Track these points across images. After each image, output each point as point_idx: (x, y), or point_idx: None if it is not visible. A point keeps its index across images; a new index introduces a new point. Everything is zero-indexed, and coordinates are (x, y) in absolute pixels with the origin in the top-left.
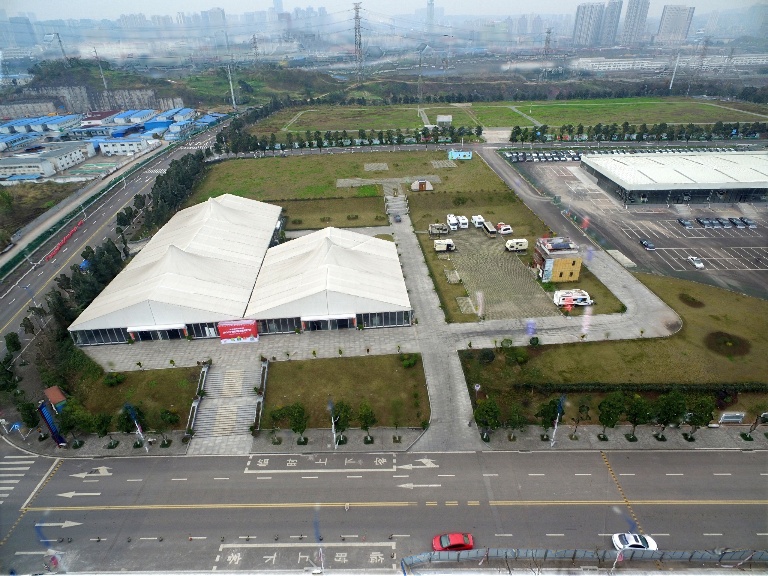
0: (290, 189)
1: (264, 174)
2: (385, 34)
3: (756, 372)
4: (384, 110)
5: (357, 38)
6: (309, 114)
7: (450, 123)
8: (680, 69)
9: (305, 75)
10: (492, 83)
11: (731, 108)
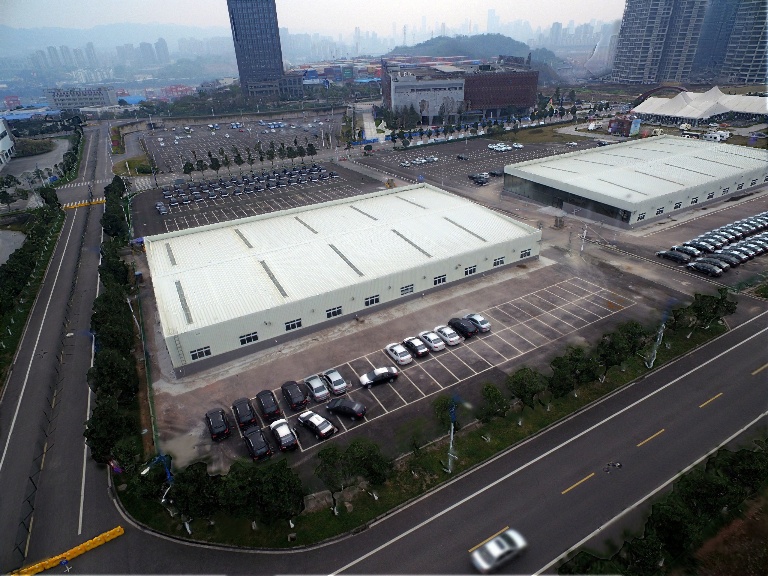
0: None
1: None
2: None
3: None
4: None
5: None
6: None
7: None
8: None
9: None
10: None
11: None
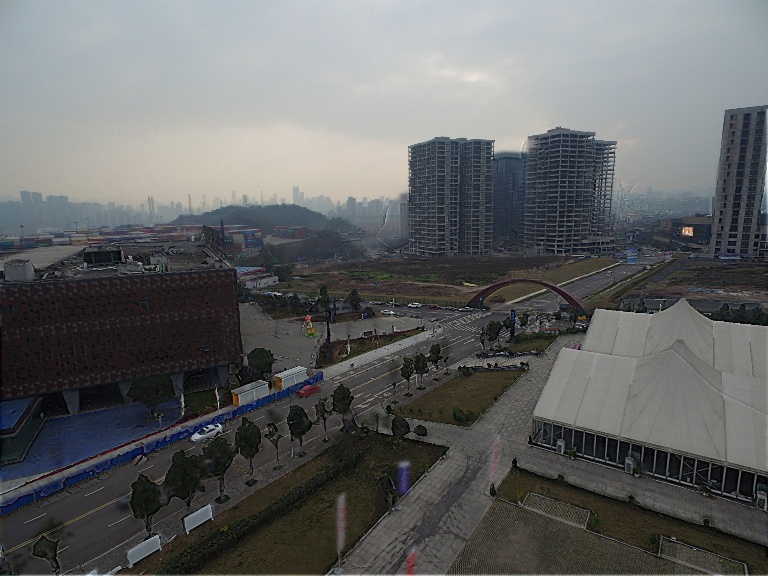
0: None
1: None
2: None
3: None
4: None
5: None
6: None
7: None
8: None
9: None
10: None
11: None
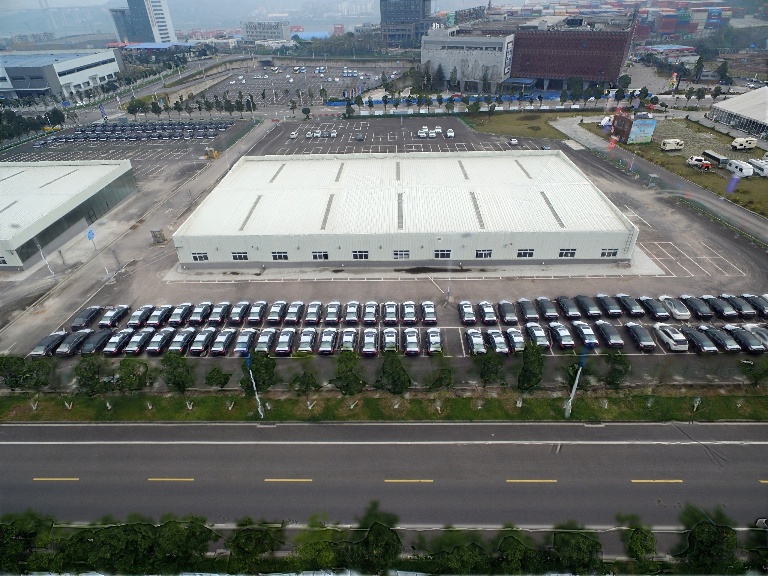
0: None
1: None
2: None
3: (523, 114)
4: None
5: None
6: None
7: None
8: None
9: None
10: None
11: None
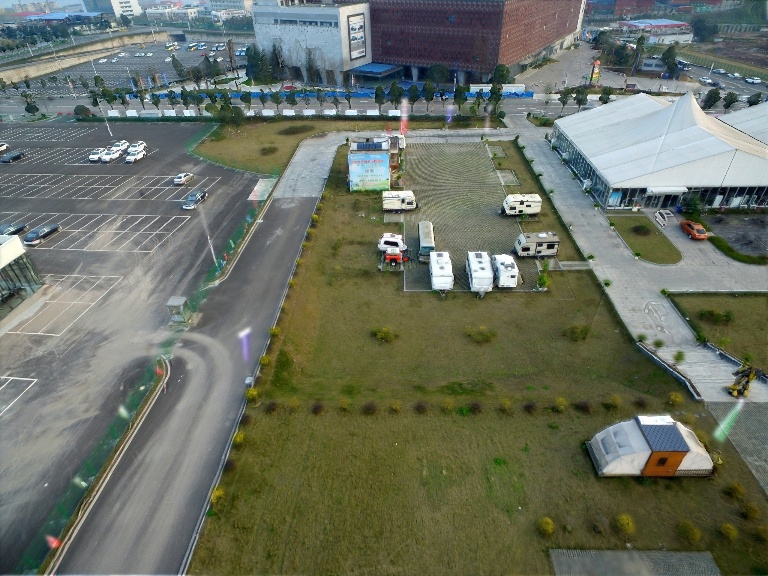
0: None
1: None
2: None
3: (303, 123)
4: None
5: None
6: None
7: None
8: None
9: None
10: None
11: None
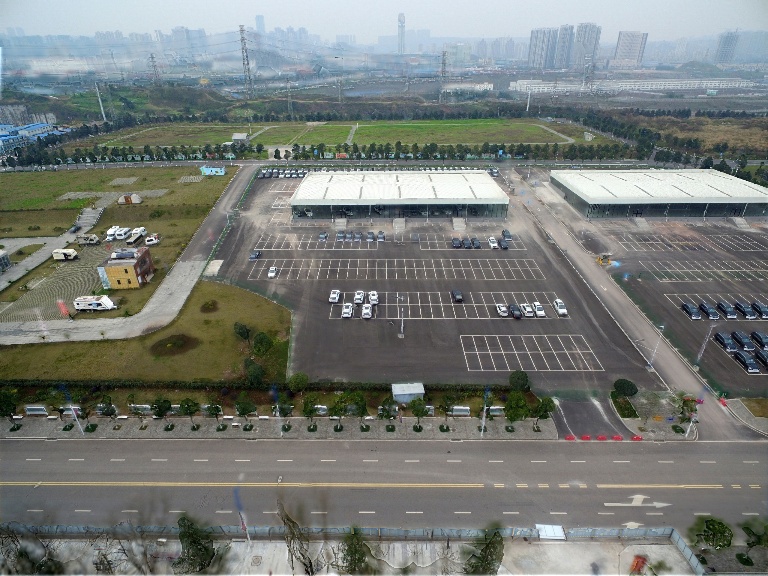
0: (9, 201)
1: (7, 187)
2: (275, 55)
3: (161, 370)
4: (232, 128)
5: (244, 58)
6: (154, 130)
7: (245, 141)
8: (537, 92)
9: (192, 93)
10: (385, 103)
11: (552, 130)
